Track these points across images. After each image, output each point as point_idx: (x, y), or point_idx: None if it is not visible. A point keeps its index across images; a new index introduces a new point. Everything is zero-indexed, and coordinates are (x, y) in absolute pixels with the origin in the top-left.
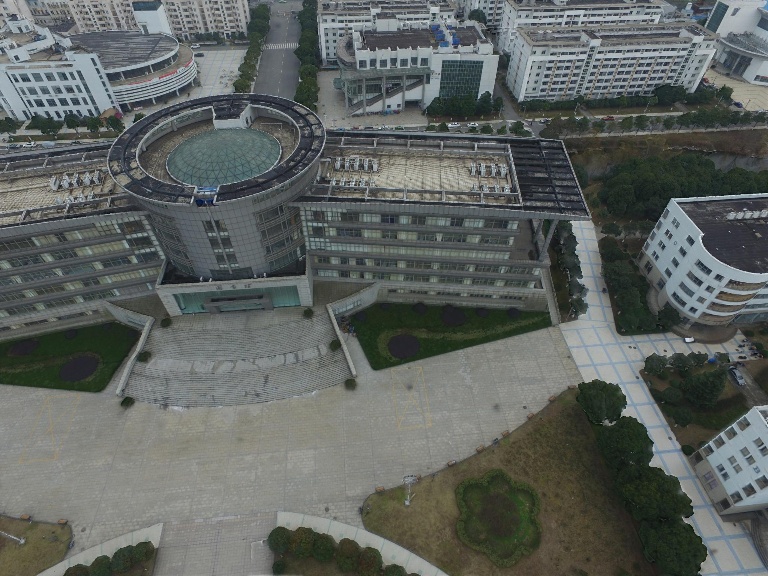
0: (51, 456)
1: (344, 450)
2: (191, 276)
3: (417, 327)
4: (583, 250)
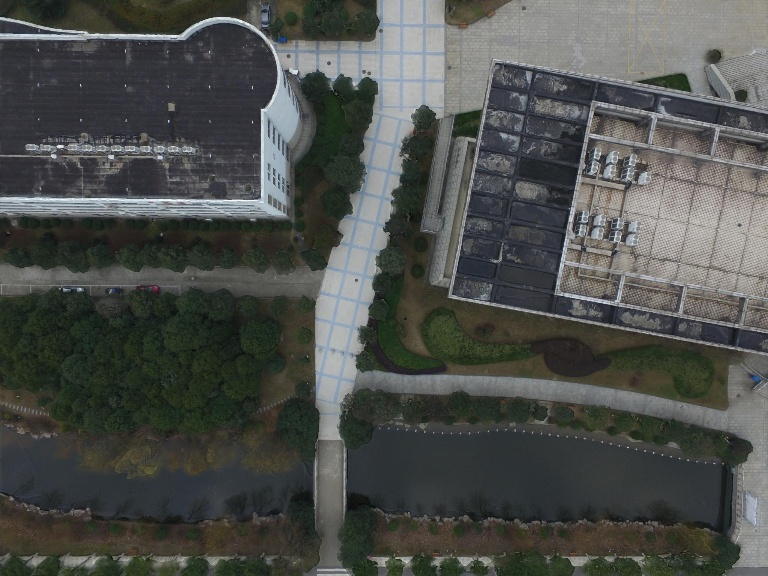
0: None
1: None
2: None
3: None
4: (357, 248)
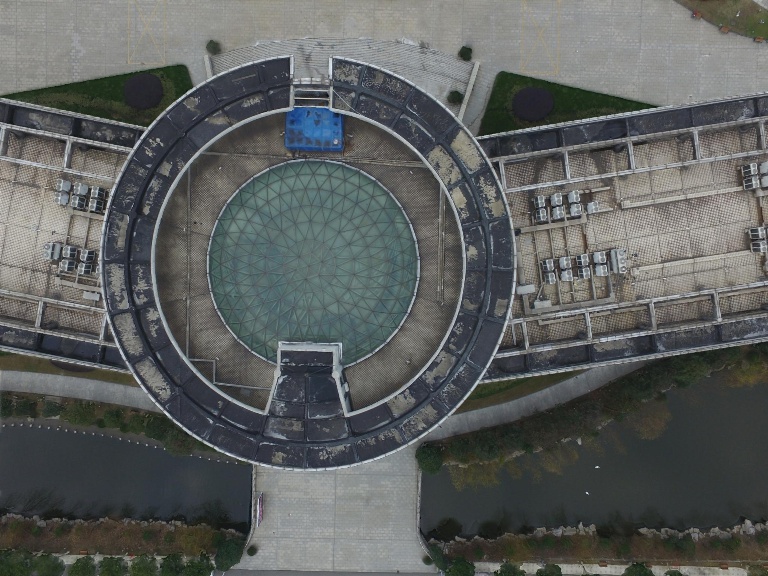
0: (529, 1)
1: None
2: None
3: (123, 121)
4: None
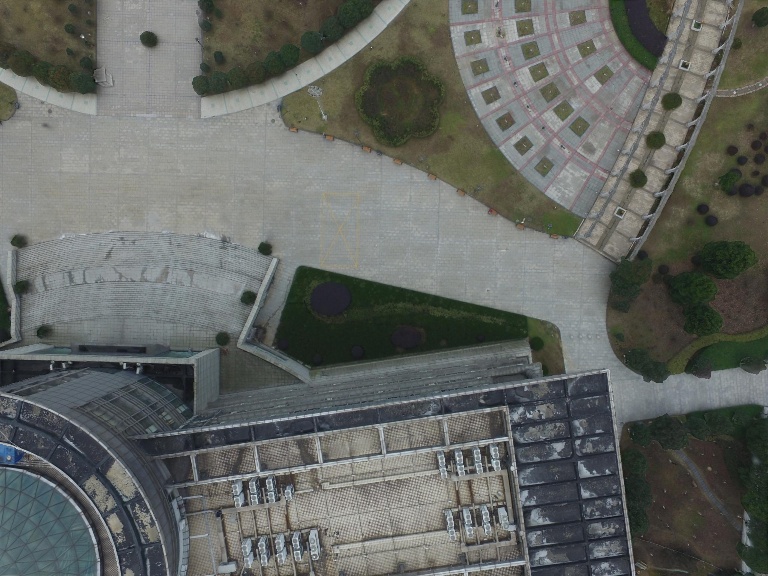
0: (328, 197)
1: (31, 167)
2: (160, 383)
3: None
4: None
